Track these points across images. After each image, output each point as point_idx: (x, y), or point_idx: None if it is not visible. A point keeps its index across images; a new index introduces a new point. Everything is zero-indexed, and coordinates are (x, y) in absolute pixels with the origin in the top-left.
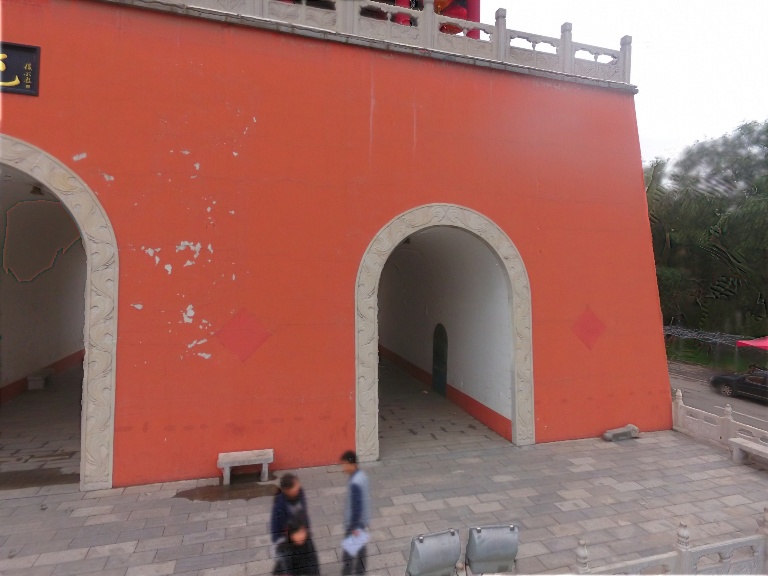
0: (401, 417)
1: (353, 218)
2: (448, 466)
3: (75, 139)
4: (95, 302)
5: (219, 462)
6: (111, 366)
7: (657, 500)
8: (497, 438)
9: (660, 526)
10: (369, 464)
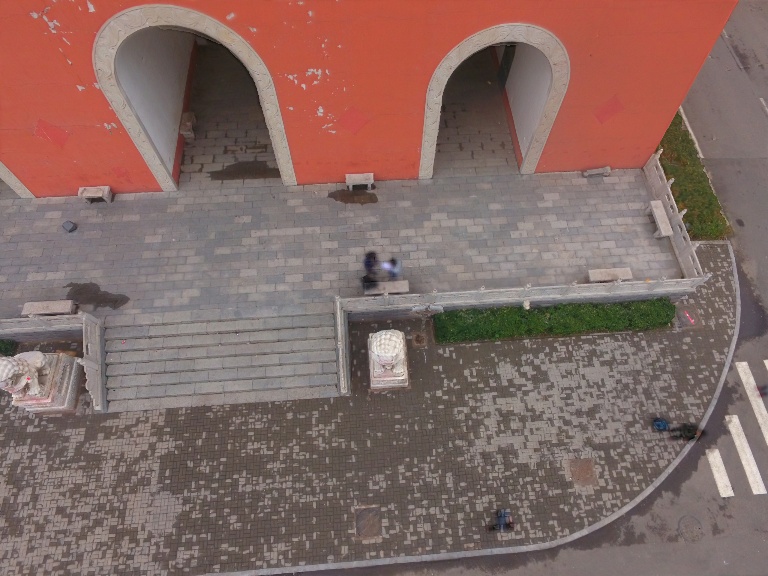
0: (459, 124)
1: (430, 42)
2: (469, 190)
3: (222, 2)
4: (267, 107)
5: (347, 183)
6: (284, 138)
7: (566, 238)
8: (512, 163)
9: (551, 256)
10: (426, 181)
